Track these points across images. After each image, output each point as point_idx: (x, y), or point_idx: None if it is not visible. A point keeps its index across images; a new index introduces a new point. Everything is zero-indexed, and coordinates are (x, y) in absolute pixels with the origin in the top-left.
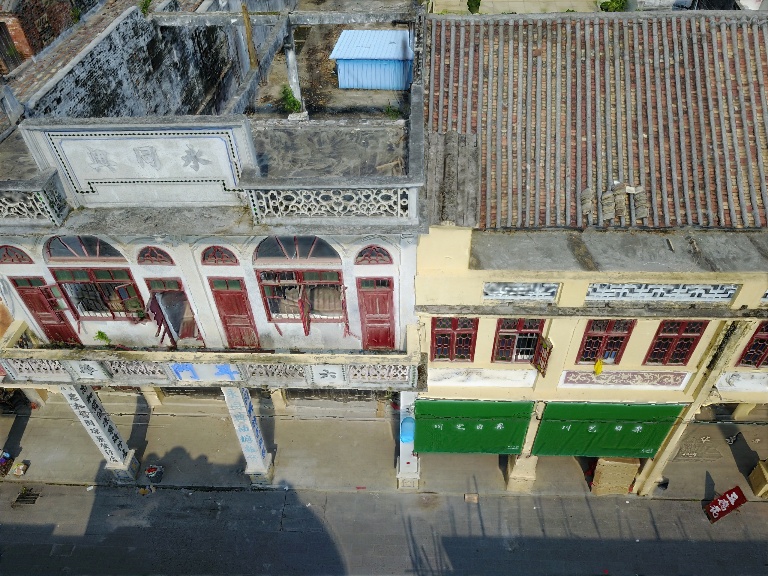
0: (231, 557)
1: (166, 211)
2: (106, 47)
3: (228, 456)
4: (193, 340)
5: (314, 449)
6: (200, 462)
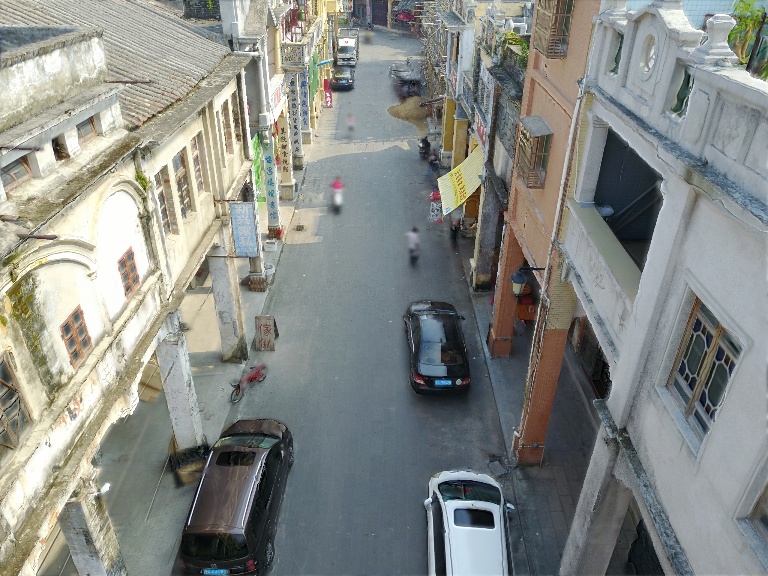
0: (342, 173)
1: None
2: None
3: None
4: None
5: None
6: None
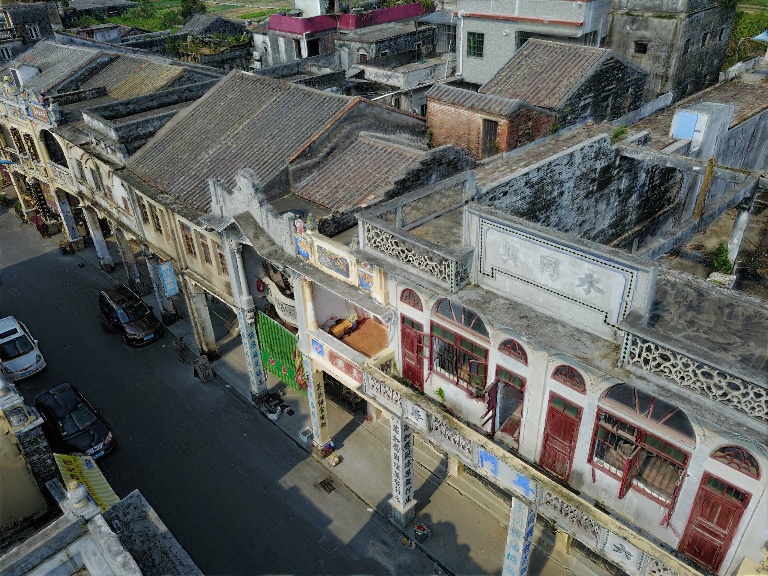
0: None
1: (542, 317)
2: (564, 162)
3: (488, 562)
4: (510, 438)
5: None
6: (462, 550)
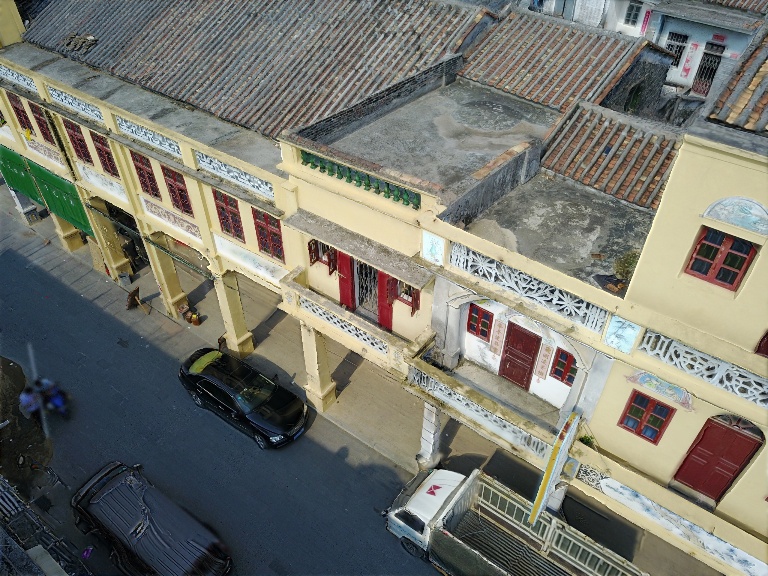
0: None
1: None
2: None
3: None
4: None
5: None
6: None
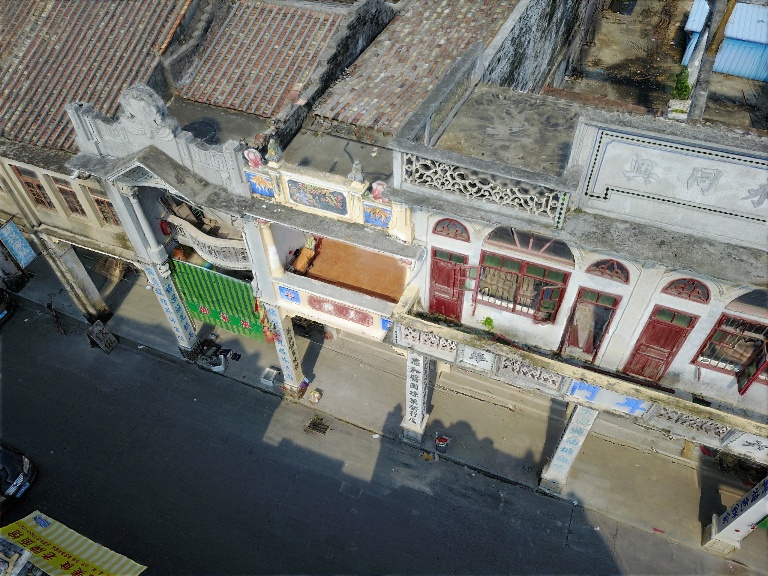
0: (514, 557)
1: (682, 238)
2: (535, 1)
3: (514, 448)
4: (579, 351)
5: (607, 469)
6: (485, 445)
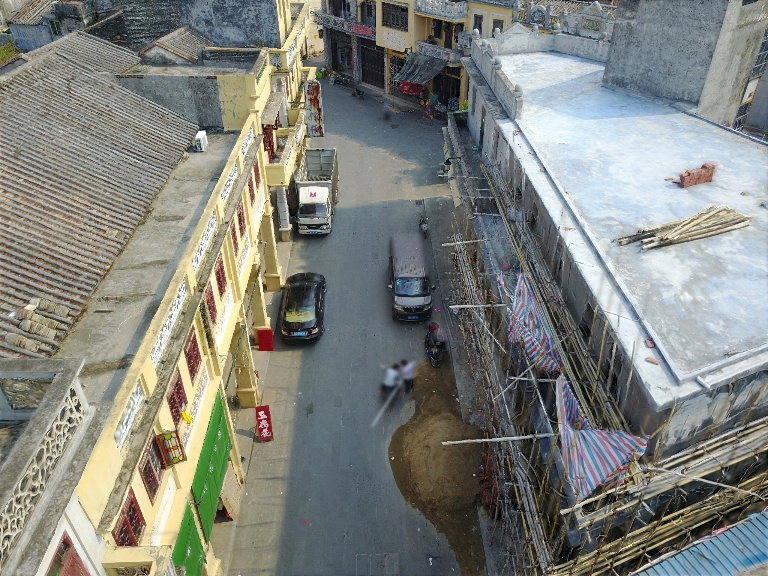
0: None
1: None
2: None
3: None
4: None
5: None
6: None
